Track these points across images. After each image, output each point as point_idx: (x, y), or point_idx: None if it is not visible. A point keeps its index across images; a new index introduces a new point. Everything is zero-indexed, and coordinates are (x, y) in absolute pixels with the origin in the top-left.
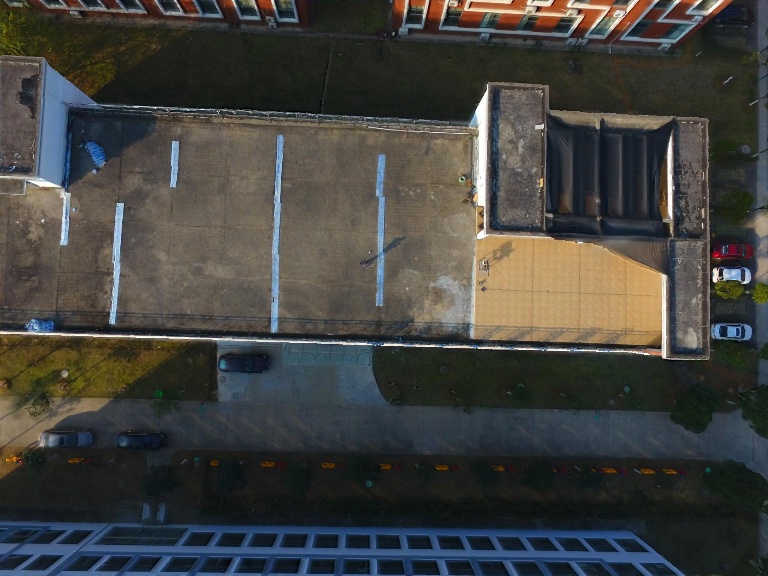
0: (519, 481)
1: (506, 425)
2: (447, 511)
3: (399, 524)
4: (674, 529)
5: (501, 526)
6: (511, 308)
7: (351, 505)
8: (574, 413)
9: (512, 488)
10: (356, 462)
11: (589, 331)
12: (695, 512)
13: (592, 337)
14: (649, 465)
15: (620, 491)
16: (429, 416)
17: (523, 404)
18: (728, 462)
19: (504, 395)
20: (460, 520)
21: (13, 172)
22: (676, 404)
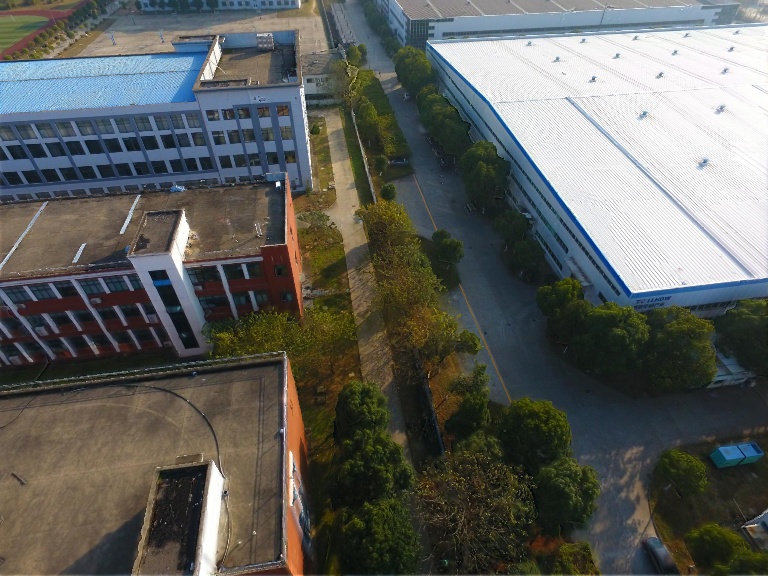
0: None
1: None
2: None
3: None
4: None
5: None
6: None
7: None
8: None
9: None
10: None
11: None
12: None
13: None
14: None
15: None
16: None
17: None
18: None
19: None
20: None
21: (158, 213)
22: None
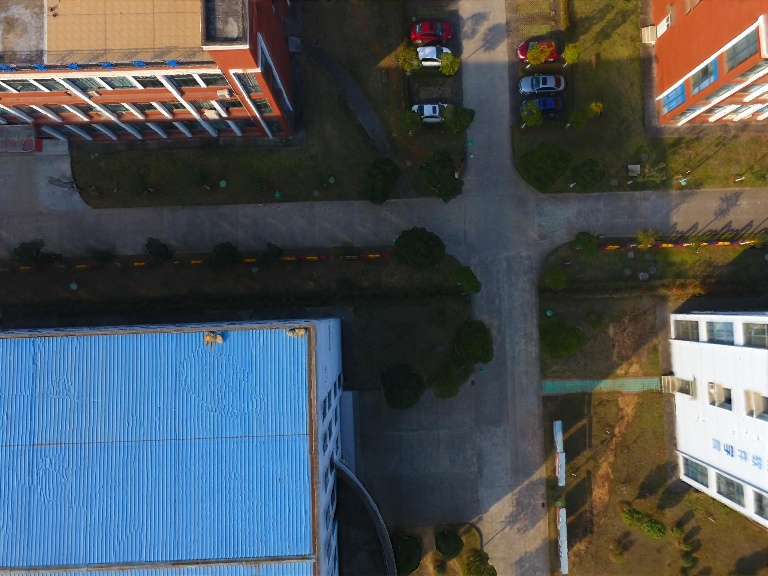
0: (224, 275)
1: (210, 222)
2: (143, 302)
3: (104, 323)
4: (384, 314)
5: (207, 319)
6: (84, 32)
7: (50, 304)
8: (278, 206)
9: (218, 283)
10: (26, 246)
11: (164, 50)
12: (403, 295)
13: (168, 56)
14: (356, 252)
15: (328, 280)
16: (131, 217)
17: (226, 200)
18: (411, 229)
19: (205, 192)
20: (163, 314)
21: None
22: (360, 178)
